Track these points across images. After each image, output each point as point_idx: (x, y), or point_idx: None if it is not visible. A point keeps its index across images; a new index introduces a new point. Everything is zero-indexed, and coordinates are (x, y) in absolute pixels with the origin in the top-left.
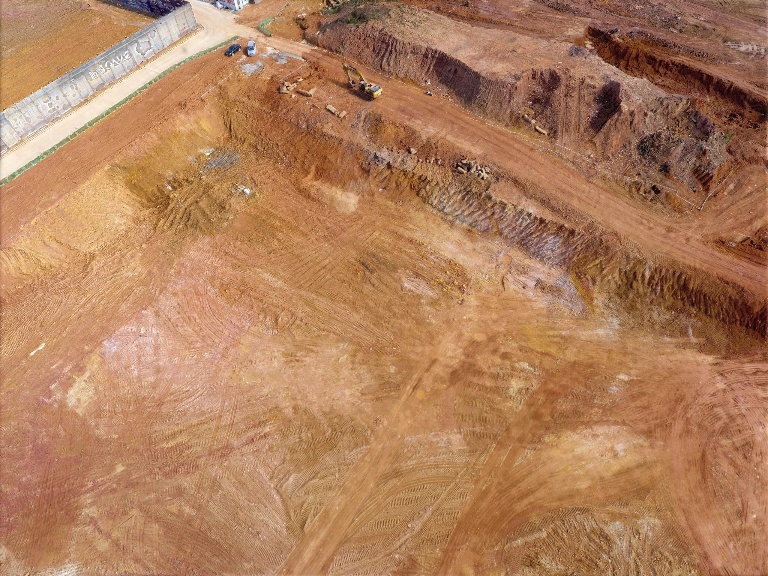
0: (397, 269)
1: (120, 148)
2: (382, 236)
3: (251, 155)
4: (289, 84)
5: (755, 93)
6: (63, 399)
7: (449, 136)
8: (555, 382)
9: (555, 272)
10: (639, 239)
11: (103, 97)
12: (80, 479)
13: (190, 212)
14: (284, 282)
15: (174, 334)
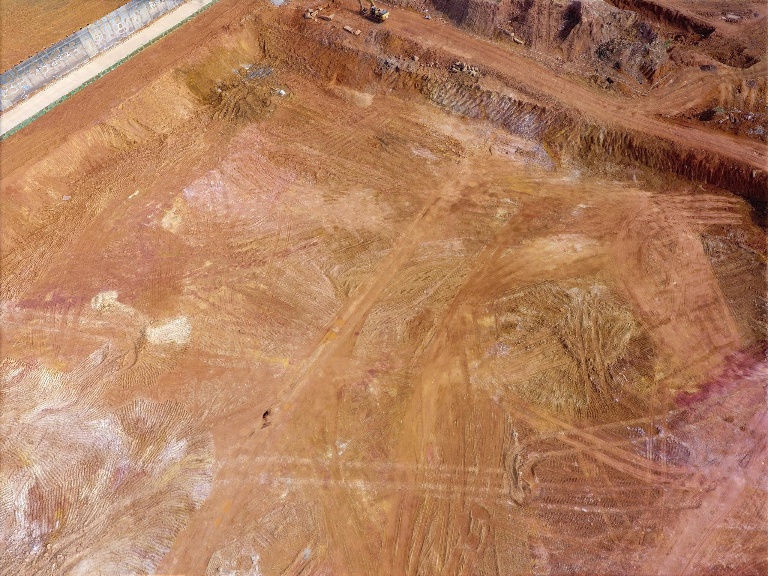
0: (407, 142)
1: (180, 57)
2: (394, 121)
3: (283, 68)
4: (312, 11)
5: (696, 19)
6: (159, 224)
7: (445, 47)
8: (531, 209)
9: (531, 143)
10: (595, 113)
11: (160, 23)
12: (180, 270)
13: (239, 105)
14: (319, 151)
15: (237, 185)
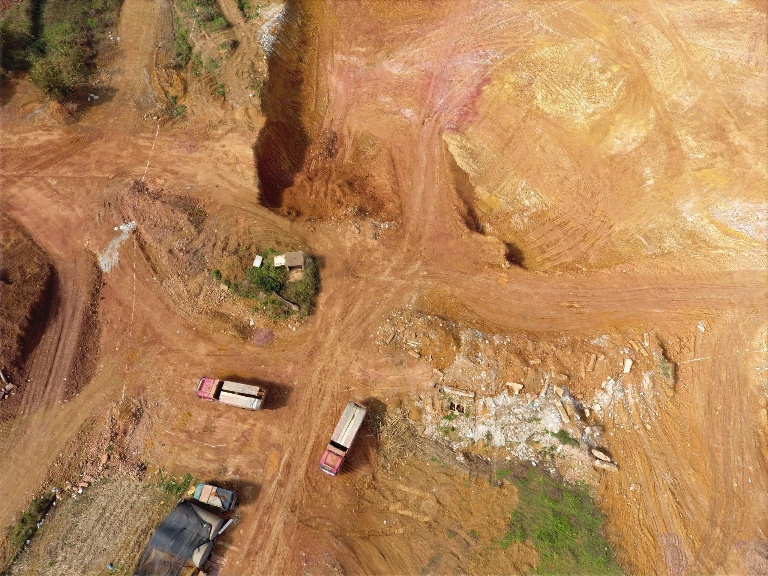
0: None
1: None
2: None
3: None
4: None
5: None
6: None
7: None
8: (678, 155)
9: (760, 235)
10: (762, 275)
11: None
12: None
13: None
14: None
15: None
